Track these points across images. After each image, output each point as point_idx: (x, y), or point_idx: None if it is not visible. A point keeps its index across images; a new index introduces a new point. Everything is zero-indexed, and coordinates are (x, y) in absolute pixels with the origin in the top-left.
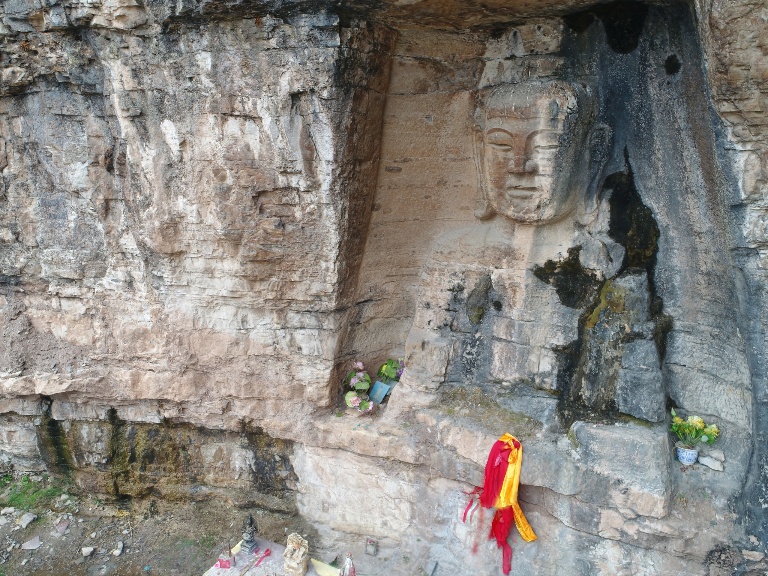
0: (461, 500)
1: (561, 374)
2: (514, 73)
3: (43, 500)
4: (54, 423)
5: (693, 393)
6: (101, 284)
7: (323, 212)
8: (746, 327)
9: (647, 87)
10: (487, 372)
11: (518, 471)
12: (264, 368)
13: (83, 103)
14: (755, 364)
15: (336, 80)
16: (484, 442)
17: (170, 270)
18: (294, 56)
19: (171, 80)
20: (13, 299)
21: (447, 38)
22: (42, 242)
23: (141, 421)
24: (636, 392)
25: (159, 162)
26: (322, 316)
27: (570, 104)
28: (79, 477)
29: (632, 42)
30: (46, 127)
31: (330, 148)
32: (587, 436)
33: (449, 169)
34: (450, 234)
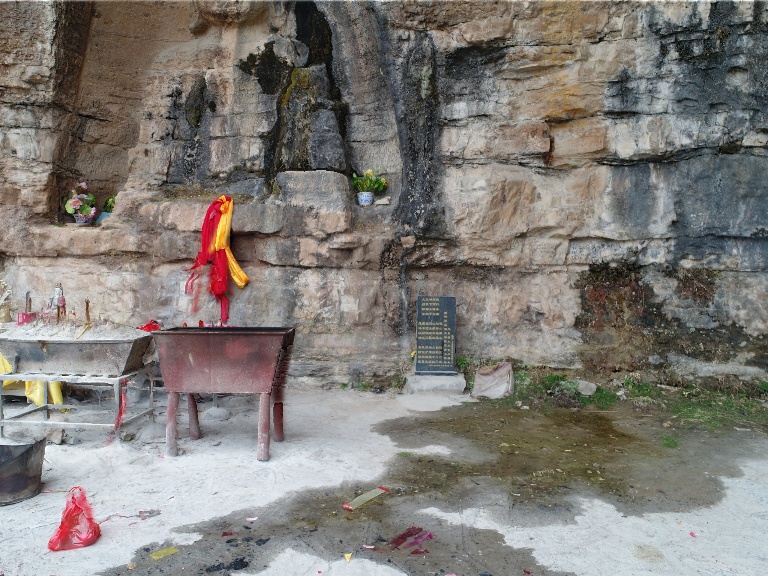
0: (183, 275)
1: (267, 154)
2: None
3: None
4: None
5: (368, 161)
6: None
7: None
8: (384, 61)
9: None
10: (206, 169)
11: (230, 218)
12: None
13: None
14: (393, 91)
15: None
16: (201, 211)
17: None
18: None
19: None
20: None
21: None
22: None
23: None
24: (322, 147)
25: None
26: (39, 111)
27: None
28: None
29: None
30: None
31: None
32: (284, 177)
33: None
34: None
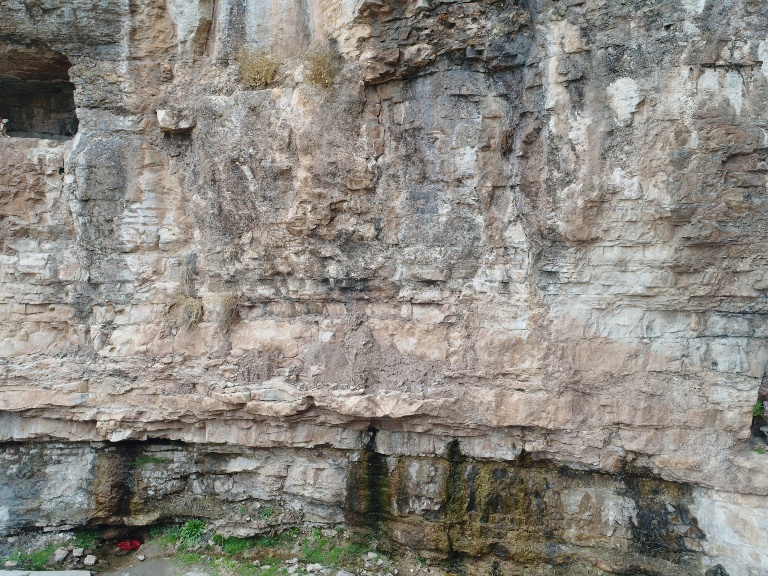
0: None
1: None
2: None
3: (348, 558)
4: (373, 459)
5: None
6: (470, 286)
7: None
8: None
9: None
10: None
11: None
12: (667, 388)
13: (484, 82)
14: None
15: None
16: None
17: (573, 263)
18: None
19: (637, 32)
20: (355, 307)
21: None
22: (403, 240)
23: (487, 457)
24: None
25: (596, 130)
26: (759, 319)
27: None
28: (399, 528)
29: None
30: (438, 109)
31: None
32: None
33: None
34: None
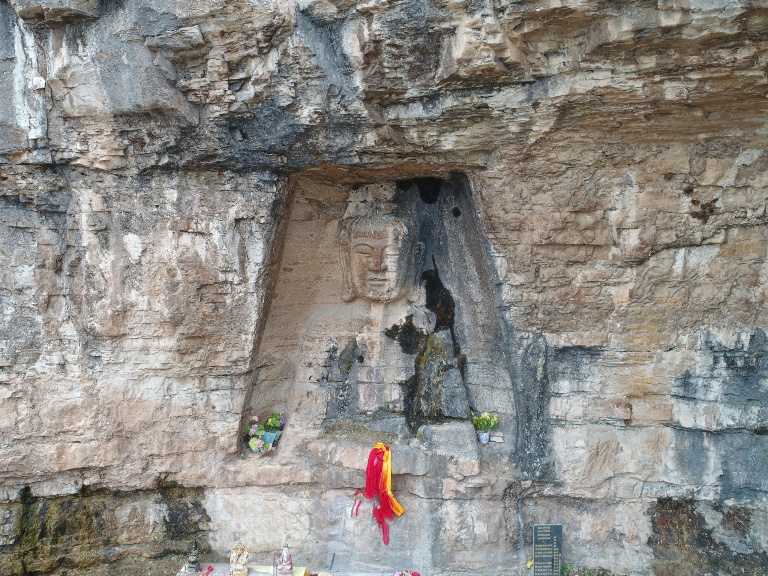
0: (348, 501)
1: (406, 399)
2: (367, 211)
3: None
4: None
5: (481, 400)
6: (33, 369)
7: (248, 298)
8: (508, 350)
9: (443, 222)
10: (355, 407)
11: (390, 465)
12: (183, 427)
13: (37, 218)
14: (514, 371)
15: (272, 212)
16: (363, 453)
17: (110, 350)
18: (242, 196)
19: (139, 206)
20: None
21: (326, 188)
22: None
23: (55, 495)
24: (453, 401)
25: (118, 264)
26: (235, 378)
27: (404, 230)
28: None
29: (434, 198)
30: None
31: (260, 255)
32: (430, 432)
33: (324, 269)
34: (325, 313)
